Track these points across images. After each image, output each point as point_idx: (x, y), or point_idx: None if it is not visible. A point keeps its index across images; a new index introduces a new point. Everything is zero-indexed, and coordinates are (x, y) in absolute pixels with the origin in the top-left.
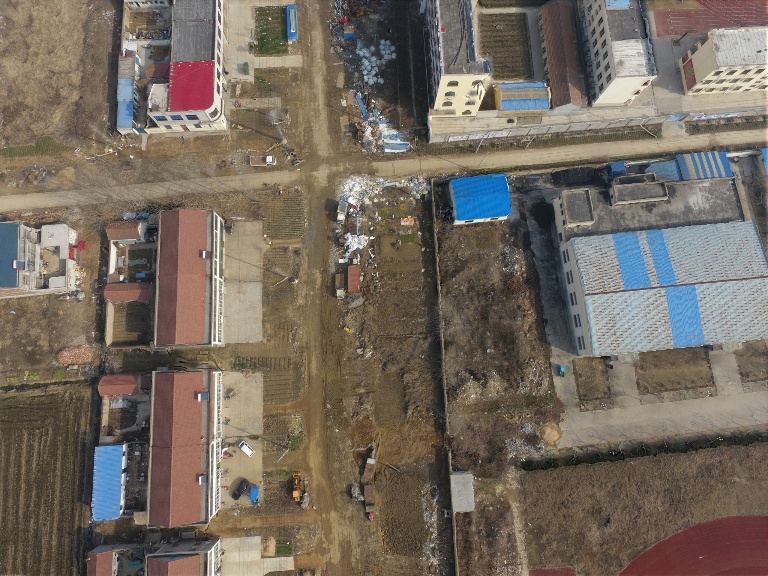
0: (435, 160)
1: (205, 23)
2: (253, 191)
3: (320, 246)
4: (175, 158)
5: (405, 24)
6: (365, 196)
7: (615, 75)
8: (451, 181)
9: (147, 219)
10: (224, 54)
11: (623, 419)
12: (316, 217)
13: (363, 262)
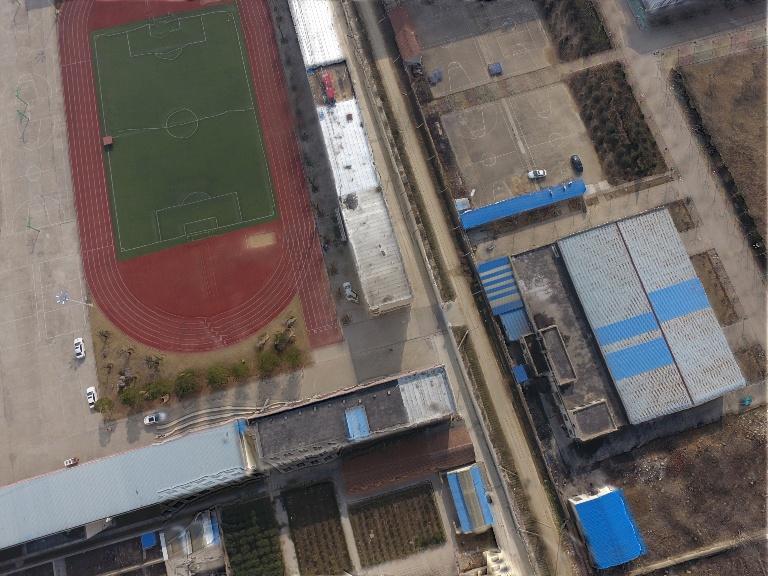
0: None
1: None
2: None
3: None
4: None
5: None
6: None
7: None
8: None
9: None
10: None
11: (767, 335)
12: None
13: None
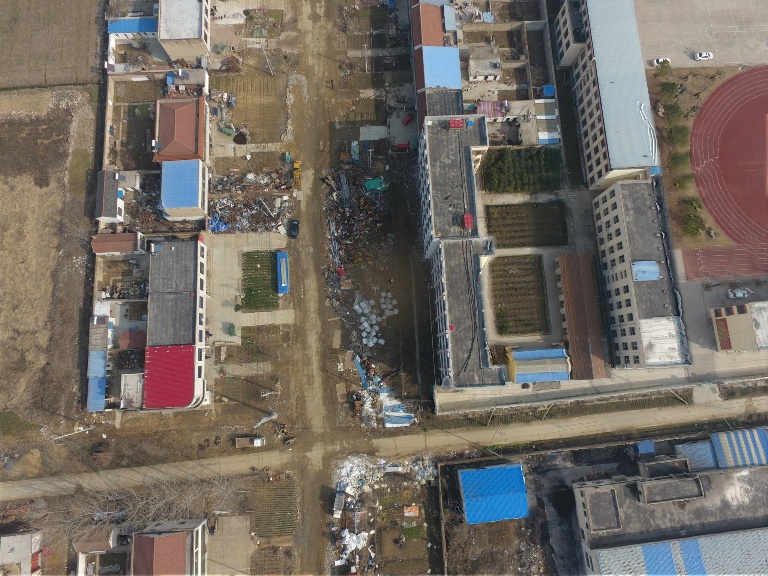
0: (442, 435)
1: (185, 296)
2: (239, 477)
3: (314, 544)
4: (153, 437)
5: (408, 270)
6: (364, 483)
7: (644, 365)
8: (460, 474)
9: (120, 525)
10: (207, 314)
11: None
12: (310, 508)
13: (362, 565)
